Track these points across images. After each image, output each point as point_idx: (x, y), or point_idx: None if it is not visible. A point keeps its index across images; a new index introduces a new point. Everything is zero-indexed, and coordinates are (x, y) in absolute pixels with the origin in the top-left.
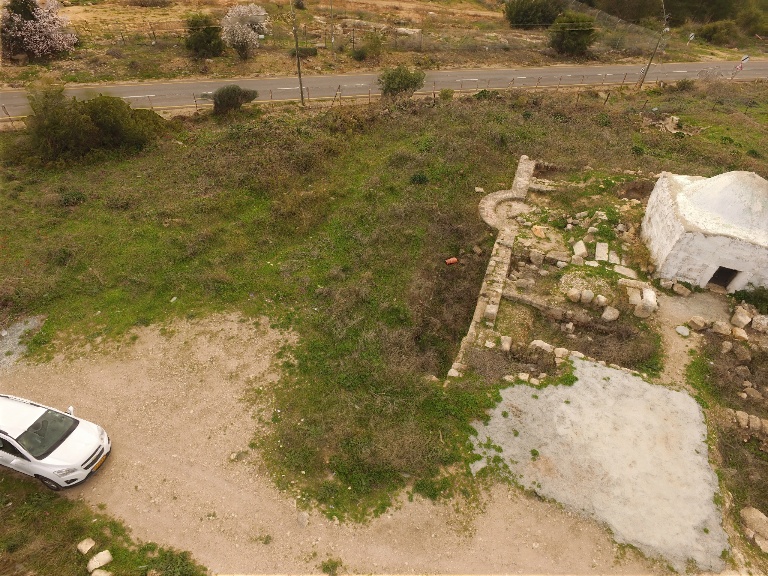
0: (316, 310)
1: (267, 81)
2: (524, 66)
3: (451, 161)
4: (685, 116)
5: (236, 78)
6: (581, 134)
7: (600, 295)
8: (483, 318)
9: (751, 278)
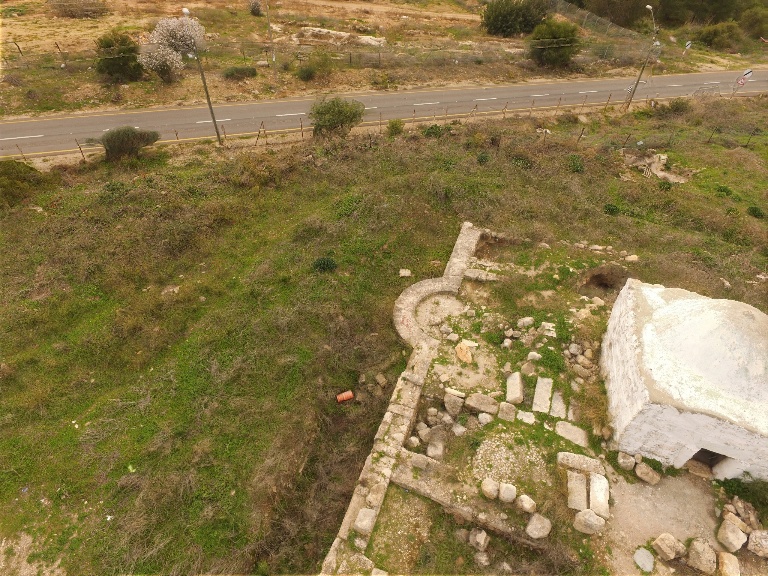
0: (108, 520)
1: (187, 112)
2: (497, 83)
3: (374, 232)
4: (675, 153)
5: (152, 108)
6: (544, 186)
7: (525, 496)
8: (353, 531)
9: (747, 467)
